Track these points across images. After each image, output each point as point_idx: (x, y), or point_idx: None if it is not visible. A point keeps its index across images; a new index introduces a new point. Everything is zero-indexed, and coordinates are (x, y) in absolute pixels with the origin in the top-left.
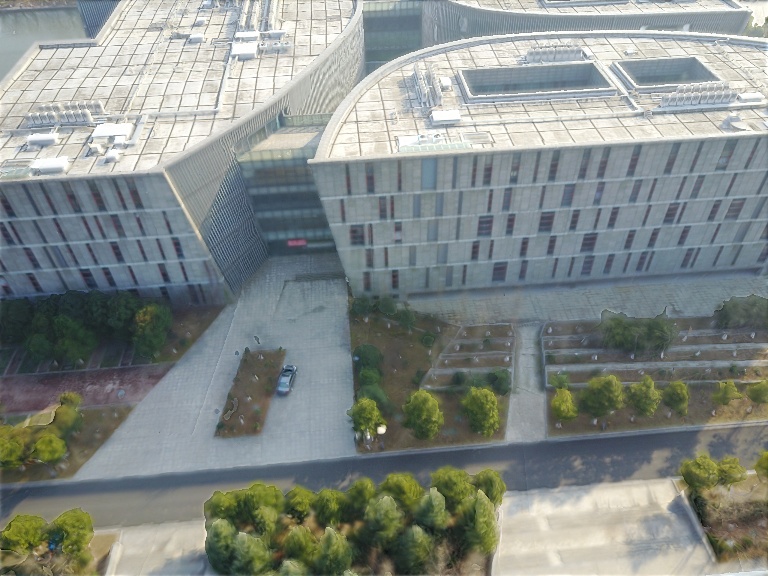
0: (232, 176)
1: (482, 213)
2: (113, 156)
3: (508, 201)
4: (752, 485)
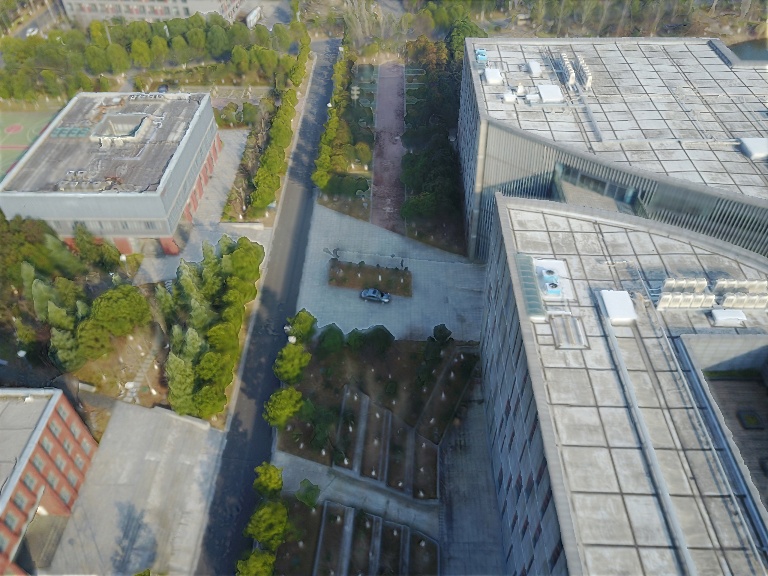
0: (538, 183)
1: None
2: (504, 97)
3: None
4: None
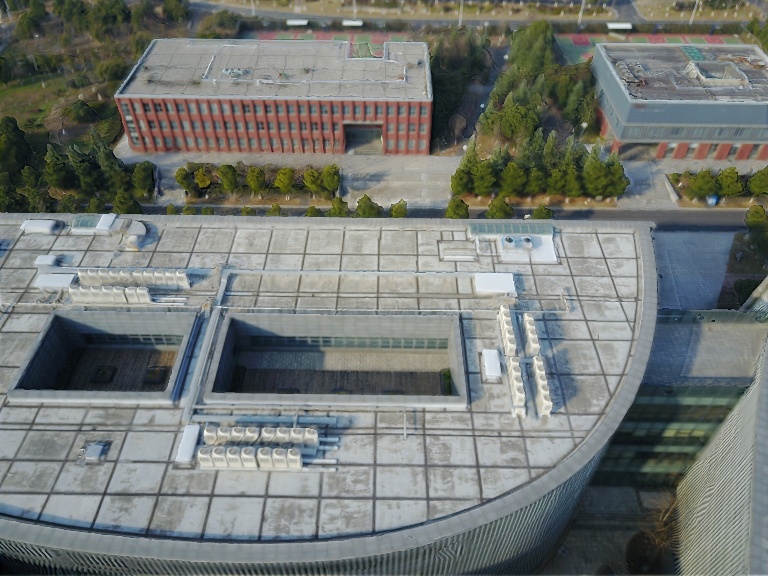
0: None
1: None
2: None
3: None
4: (289, 200)
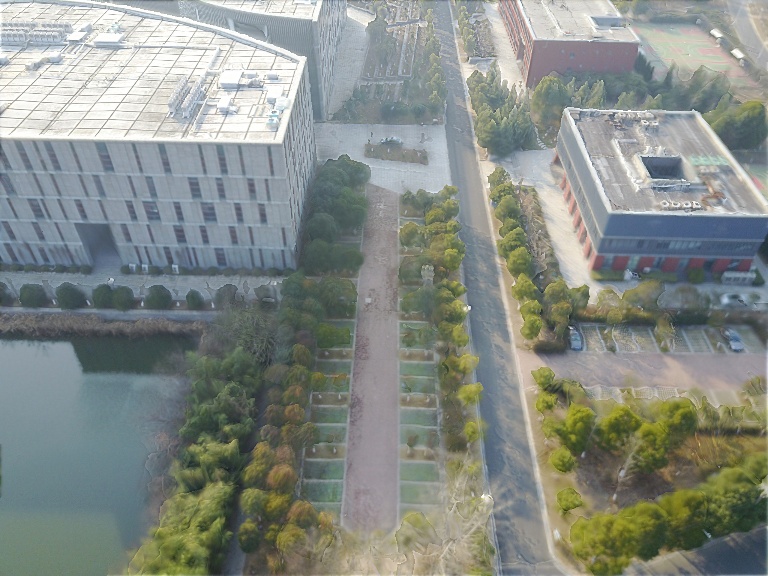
0: None
1: None
2: (276, 72)
3: None
4: (464, 51)
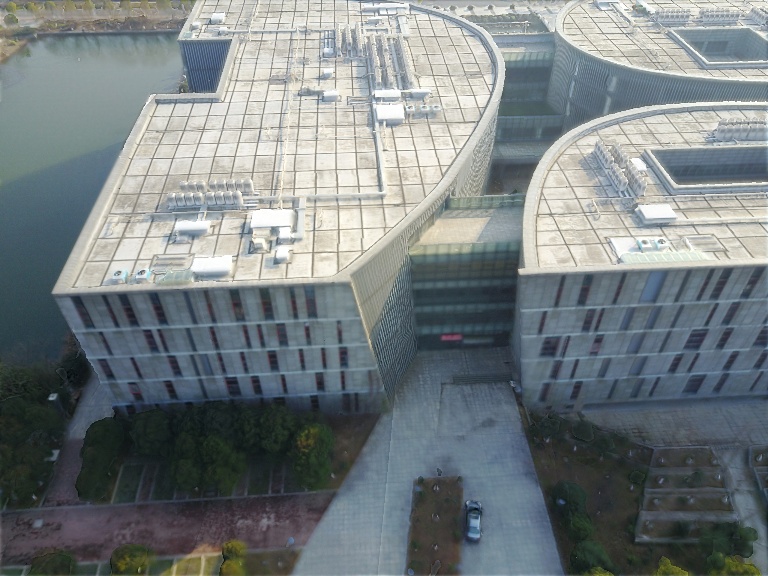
0: (403, 272)
1: (697, 326)
2: (285, 256)
3: (731, 315)
4: None
